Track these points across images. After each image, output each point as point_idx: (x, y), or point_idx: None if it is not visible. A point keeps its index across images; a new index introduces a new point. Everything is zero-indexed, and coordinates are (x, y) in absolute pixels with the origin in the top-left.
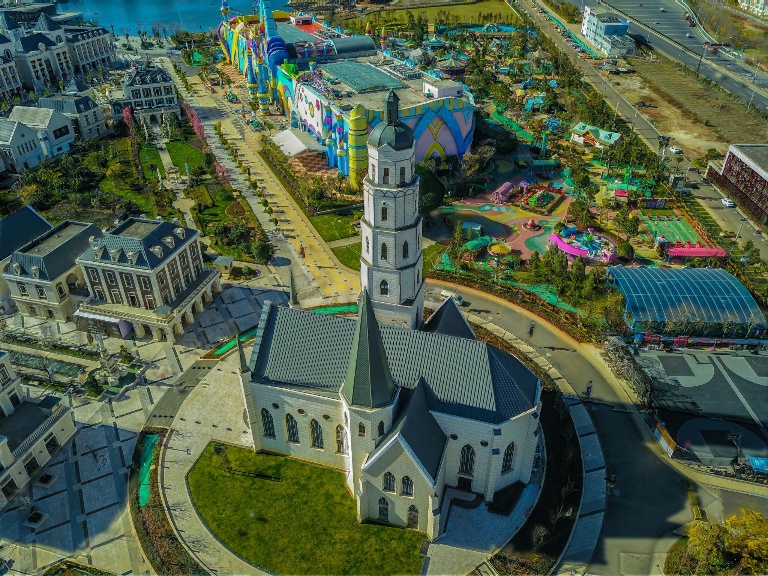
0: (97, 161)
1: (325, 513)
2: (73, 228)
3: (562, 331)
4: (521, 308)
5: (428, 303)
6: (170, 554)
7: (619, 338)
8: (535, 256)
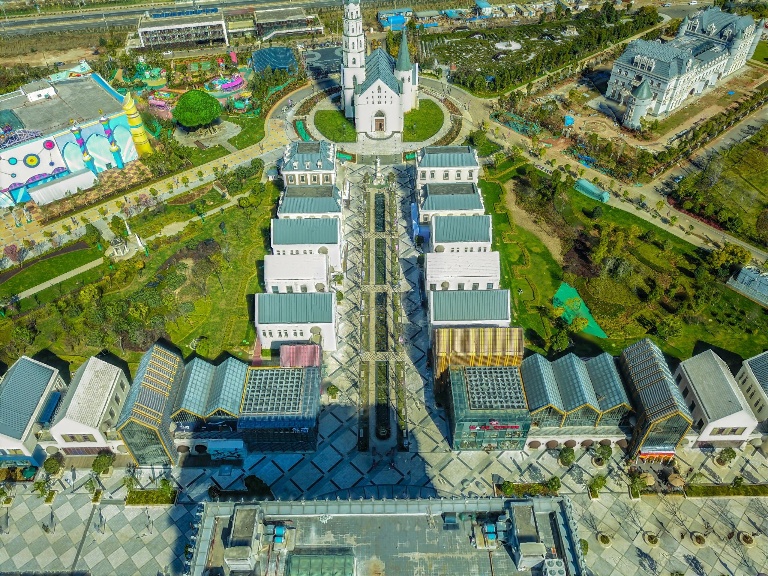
0: (97, 294)
1: (419, 115)
2: (292, 194)
3: (301, 87)
4: (286, 96)
5: (289, 116)
6: (449, 137)
7: (309, 72)
8: (258, 82)
